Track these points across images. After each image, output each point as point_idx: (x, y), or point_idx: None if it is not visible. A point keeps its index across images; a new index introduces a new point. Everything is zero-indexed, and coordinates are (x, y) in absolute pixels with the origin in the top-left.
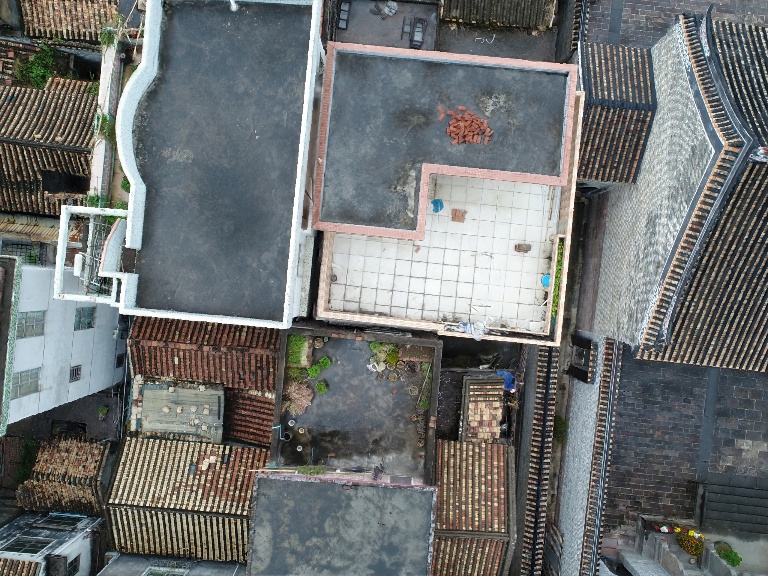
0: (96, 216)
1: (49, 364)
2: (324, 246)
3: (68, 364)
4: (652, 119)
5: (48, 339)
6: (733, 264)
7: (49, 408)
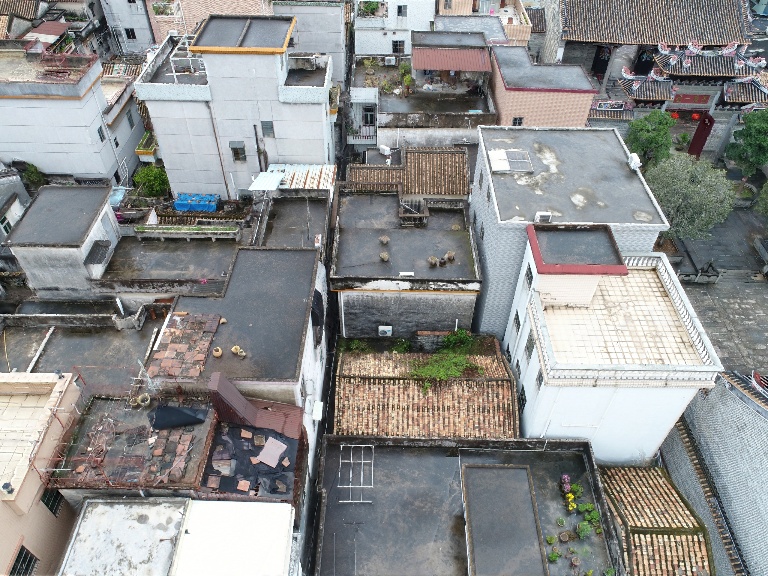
0: None
1: (342, 29)
2: None
3: None
4: (544, 11)
5: None
6: None
7: None
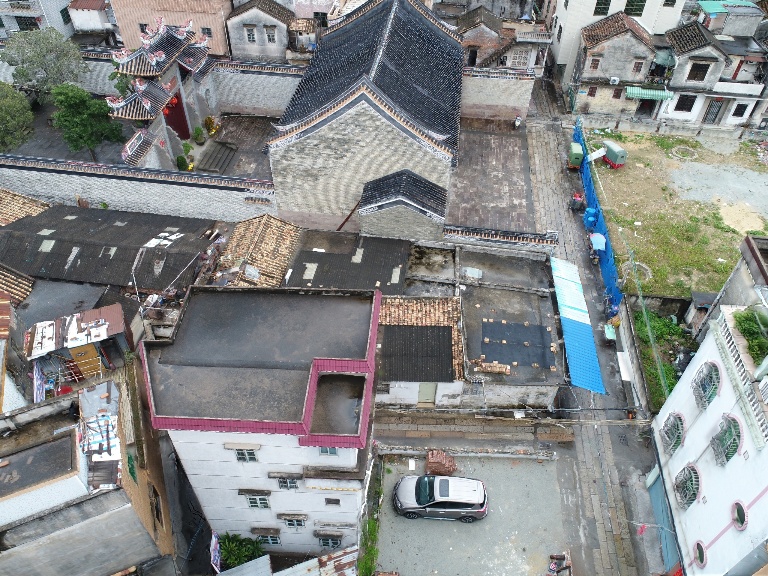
0: None
1: None
2: None
3: None
4: None
5: None
6: None
7: None
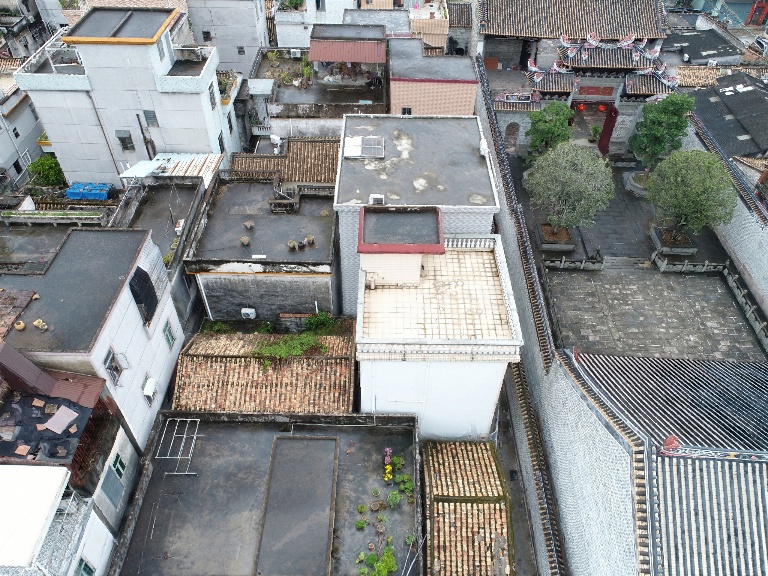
0: None
1: None
2: (361, 7)
3: (261, 38)
4: (471, 6)
5: None
6: (501, 0)
7: (257, 33)
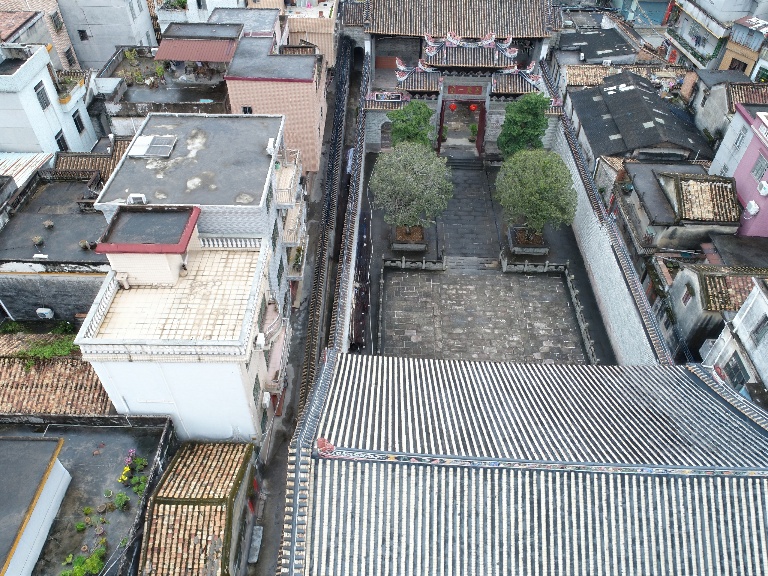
0: None
1: None
2: (248, 6)
3: (141, 37)
4: None
5: (140, 17)
6: None
7: (133, 32)
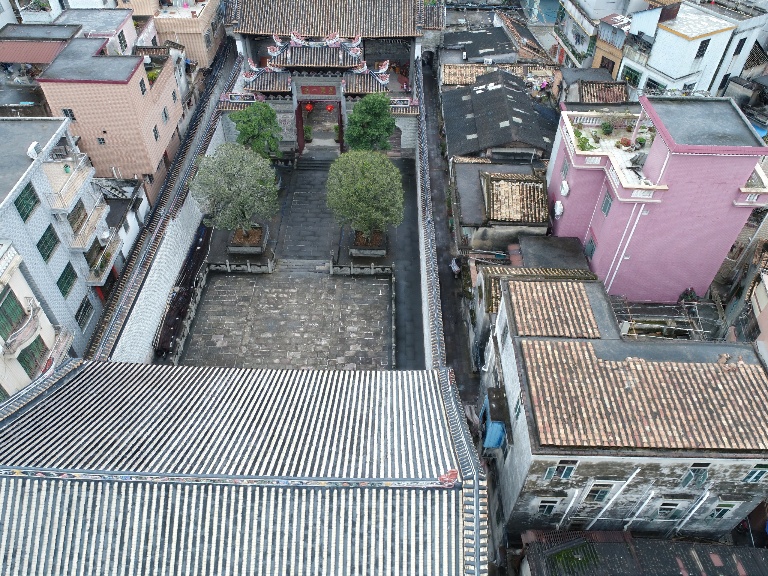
0: (35, 1)
1: None
2: None
3: None
4: None
5: None
6: None
7: None
